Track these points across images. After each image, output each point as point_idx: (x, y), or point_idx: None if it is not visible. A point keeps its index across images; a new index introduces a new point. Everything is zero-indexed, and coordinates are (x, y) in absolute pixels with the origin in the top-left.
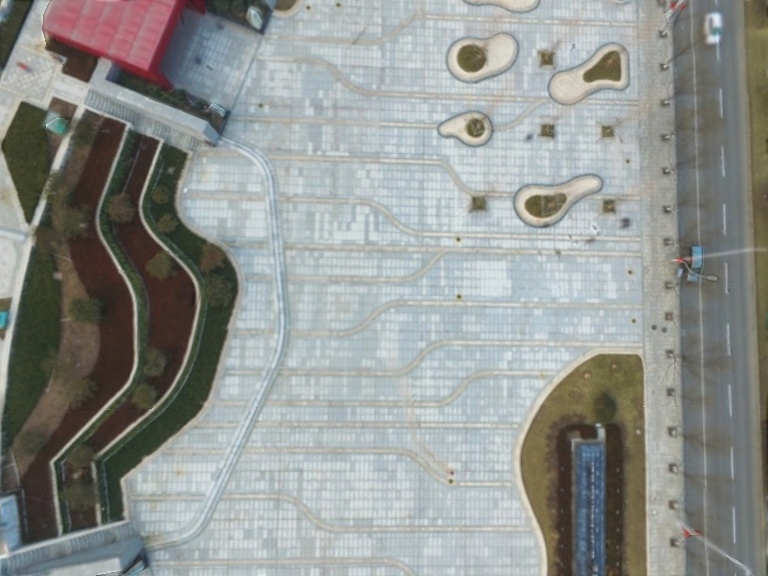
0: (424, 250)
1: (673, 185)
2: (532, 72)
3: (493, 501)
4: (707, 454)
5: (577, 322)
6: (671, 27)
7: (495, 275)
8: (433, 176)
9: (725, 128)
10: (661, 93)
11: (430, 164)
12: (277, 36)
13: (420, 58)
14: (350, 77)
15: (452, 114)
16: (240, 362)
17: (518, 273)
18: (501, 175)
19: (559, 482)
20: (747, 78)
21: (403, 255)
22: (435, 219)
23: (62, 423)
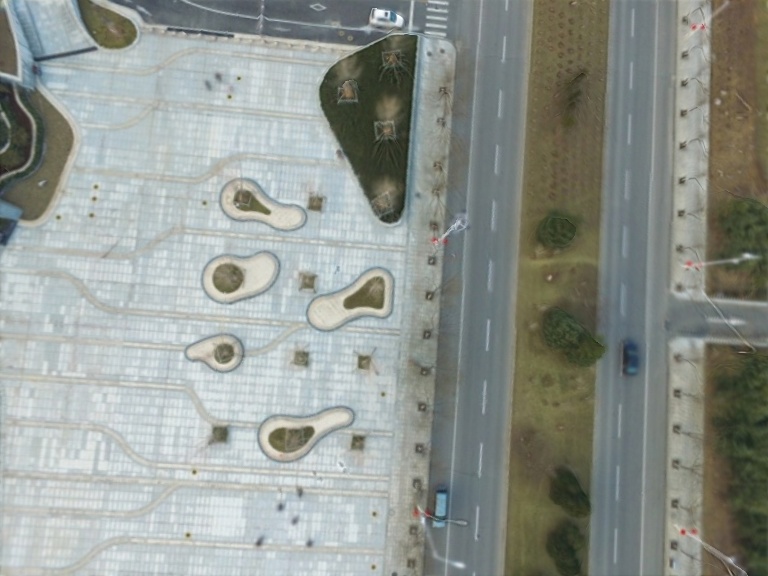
0: (156, 483)
1: (427, 423)
2: (291, 294)
3: None
4: None
5: (312, 567)
6: (441, 253)
7: (229, 513)
8: (174, 402)
9: (490, 362)
10: (425, 323)
11: (173, 389)
12: (21, 247)
13: (174, 275)
14: (96, 293)
15: (202, 336)
16: None
17: (254, 511)
18: (247, 404)
19: None
20: (516, 310)
21: (133, 487)
22: (172, 449)
23: None
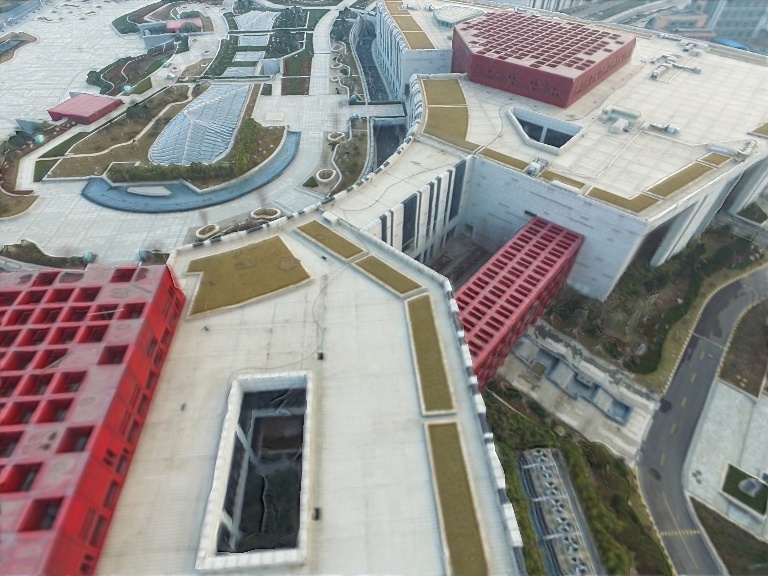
0: None
1: None
2: None
3: None
4: None
5: None
6: None
7: None
8: None
9: None
10: None
11: None
12: None
13: None
14: (5, 121)
15: None
16: (97, 70)
17: None
18: None
19: None
20: None
21: None
22: None
23: None
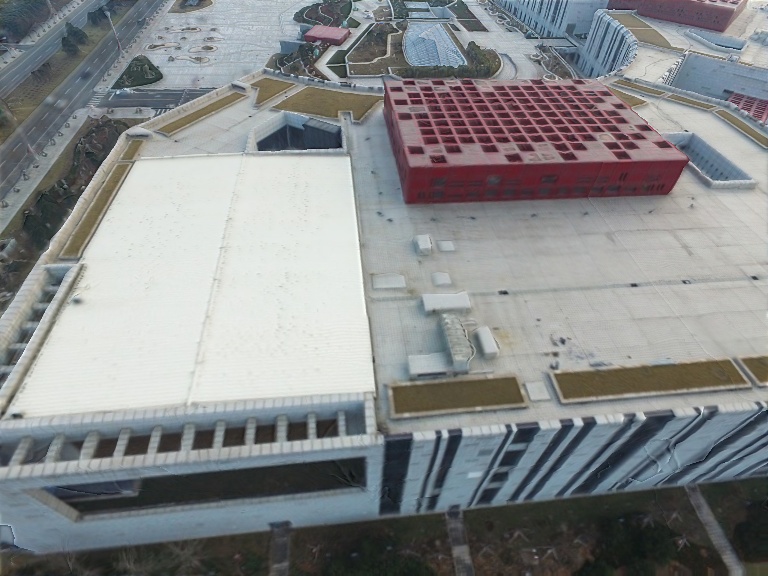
0: None
1: None
2: None
3: (222, 1)
4: (153, 4)
5: None
6: None
7: None
8: None
9: None
10: None
11: None
12: None
13: None
14: None
15: (218, 41)
16: None
17: None
18: None
19: None
20: None
21: (241, 24)
22: (229, 28)
23: (338, 3)
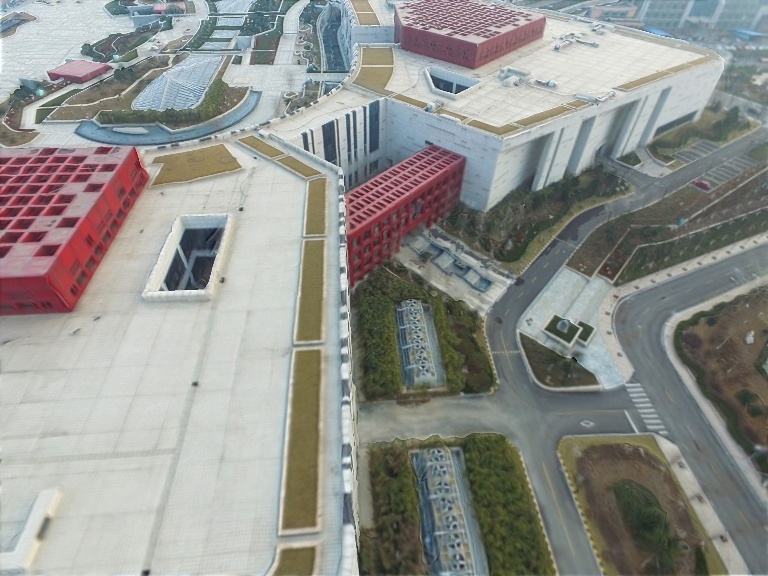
0: None
1: None
2: None
3: None
4: None
5: None
6: None
7: None
8: None
9: None
10: None
11: None
12: None
13: None
14: None
15: None
16: (90, 44)
17: None
18: None
19: (3, 32)
20: None
21: None
22: None
23: None
